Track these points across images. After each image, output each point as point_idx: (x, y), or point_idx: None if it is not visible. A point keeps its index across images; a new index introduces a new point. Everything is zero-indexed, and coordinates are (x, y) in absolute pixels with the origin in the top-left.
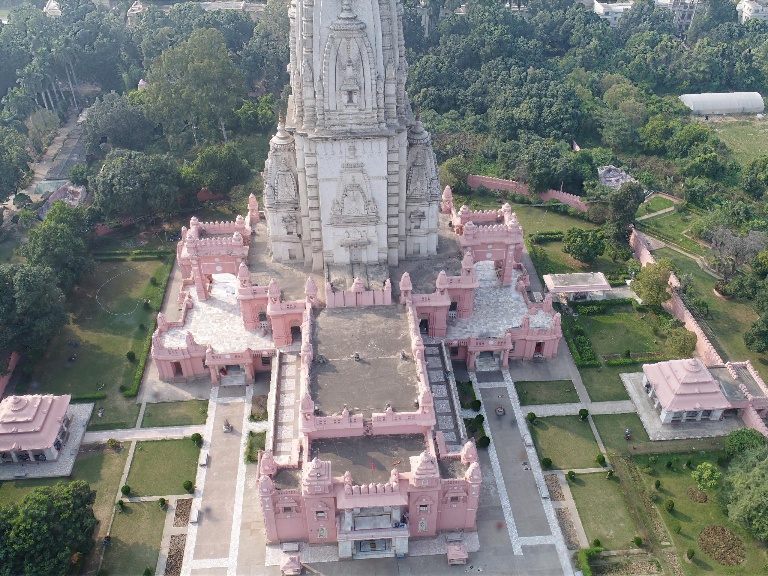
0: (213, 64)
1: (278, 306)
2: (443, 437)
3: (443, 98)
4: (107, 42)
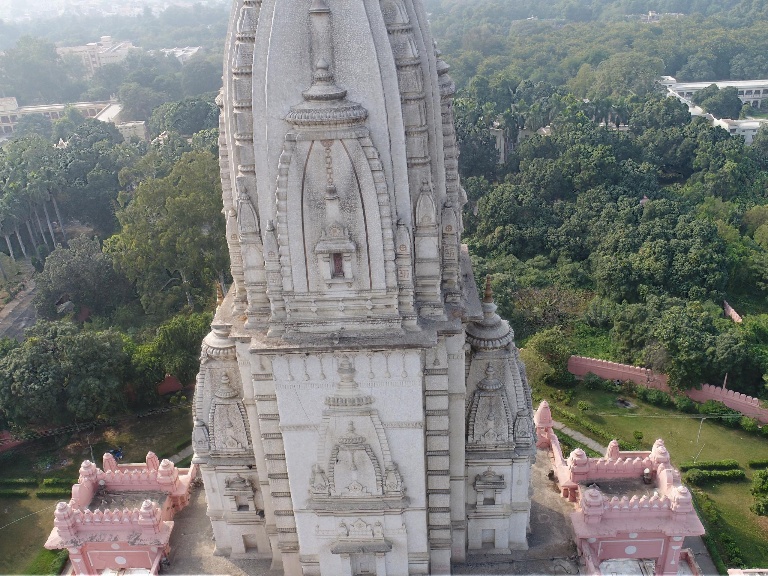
0: (201, 199)
1: None
2: None
3: (526, 239)
4: (102, 174)
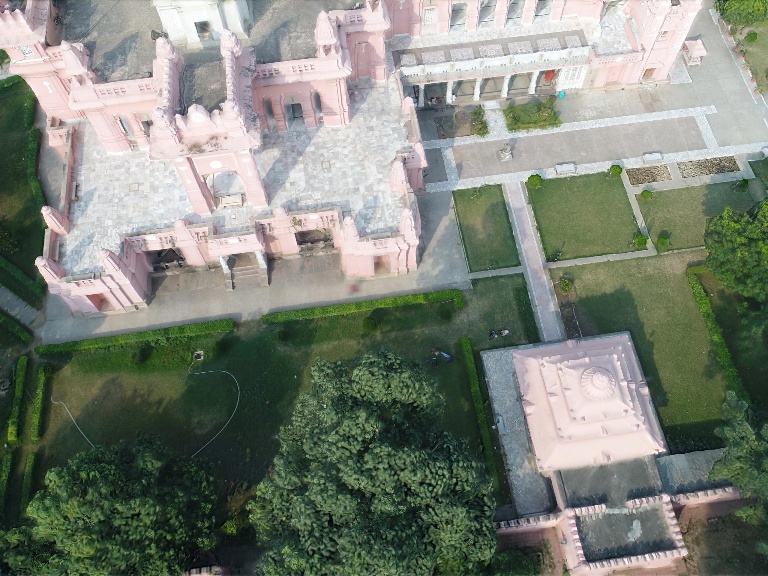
0: None
1: None
2: None
3: None
4: None
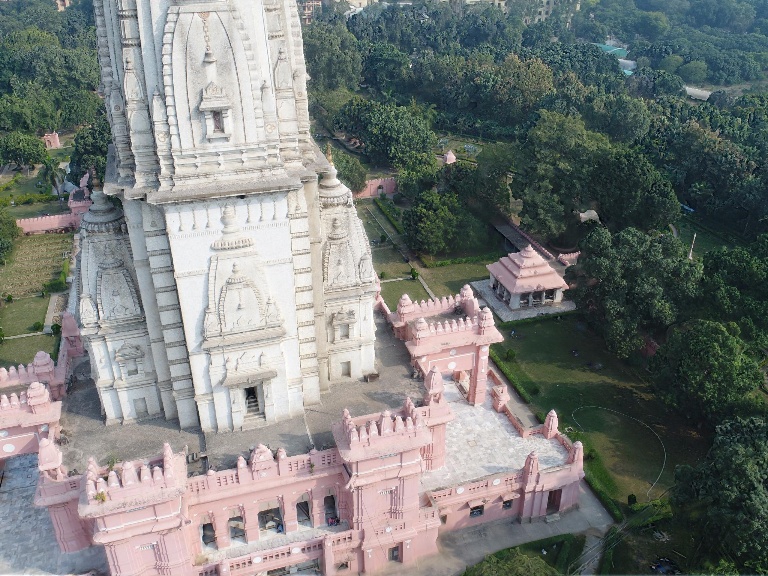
0: None
1: None
2: None
3: None
4: None
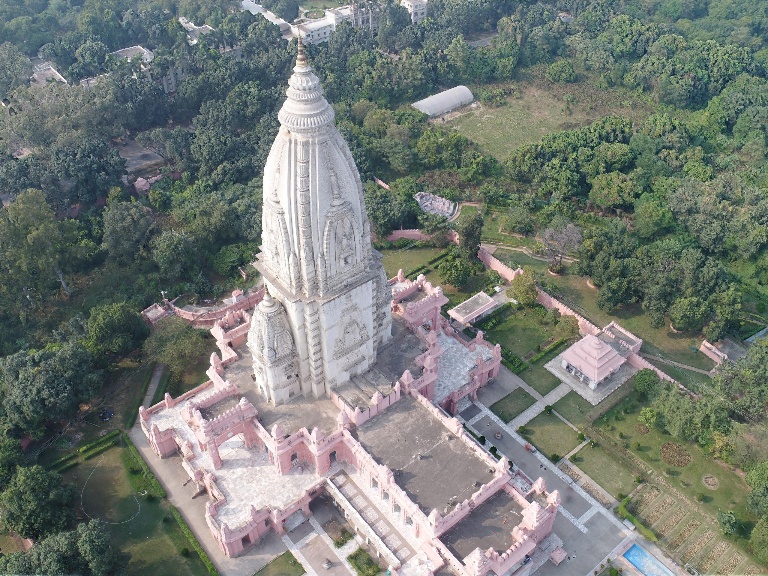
0: (51, 227)
1: (322, 445)
2: (511, 482)
3: (241, 169)
4: None
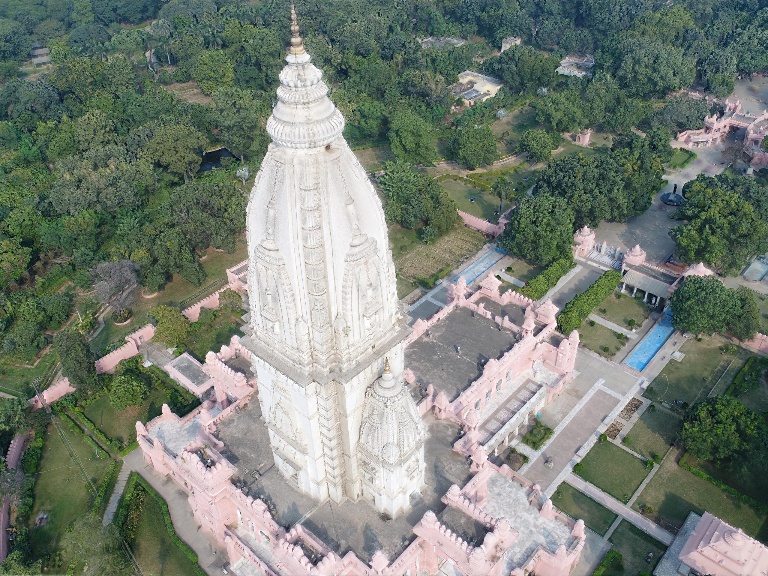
0: None
1: None
2: None
3: None
4: None
